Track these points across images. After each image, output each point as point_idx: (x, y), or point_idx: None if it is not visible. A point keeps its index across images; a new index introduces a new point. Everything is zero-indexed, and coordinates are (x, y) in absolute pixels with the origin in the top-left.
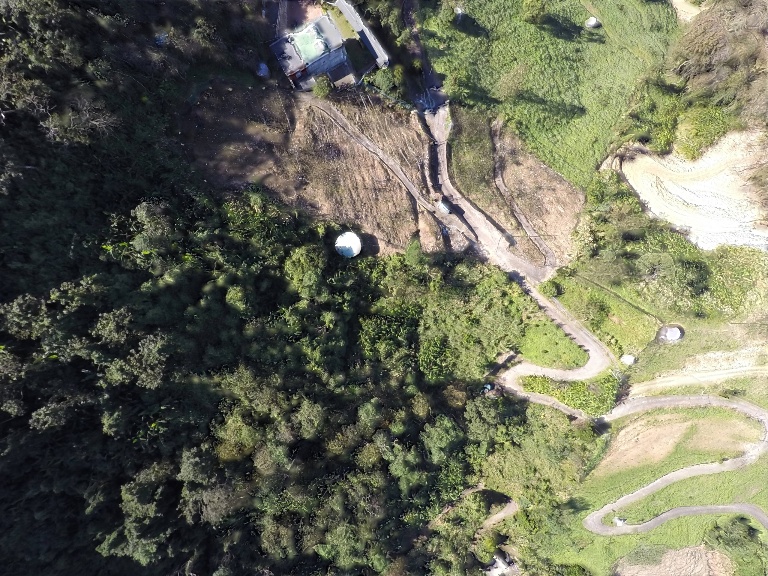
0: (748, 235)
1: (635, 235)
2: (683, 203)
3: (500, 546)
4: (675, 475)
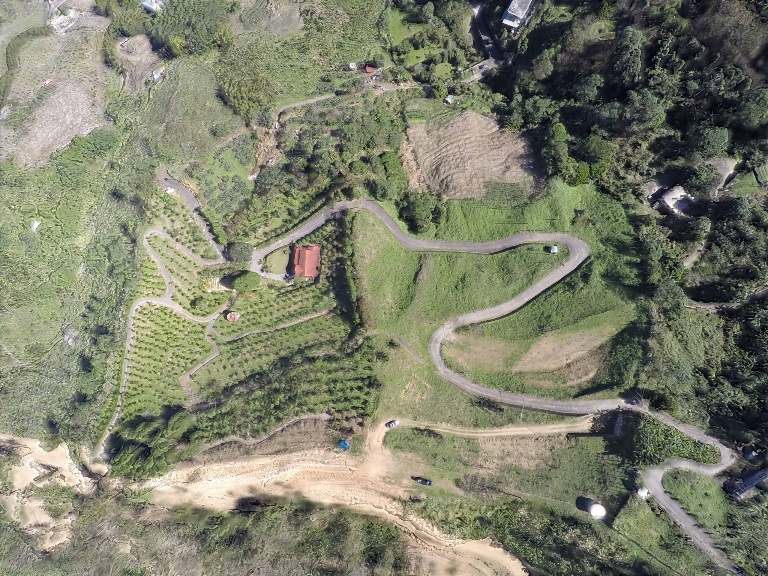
0: (454, 542)
1: (581, 574)
2: (490, 564)
3: (661, 216)
4: (513, 307)
